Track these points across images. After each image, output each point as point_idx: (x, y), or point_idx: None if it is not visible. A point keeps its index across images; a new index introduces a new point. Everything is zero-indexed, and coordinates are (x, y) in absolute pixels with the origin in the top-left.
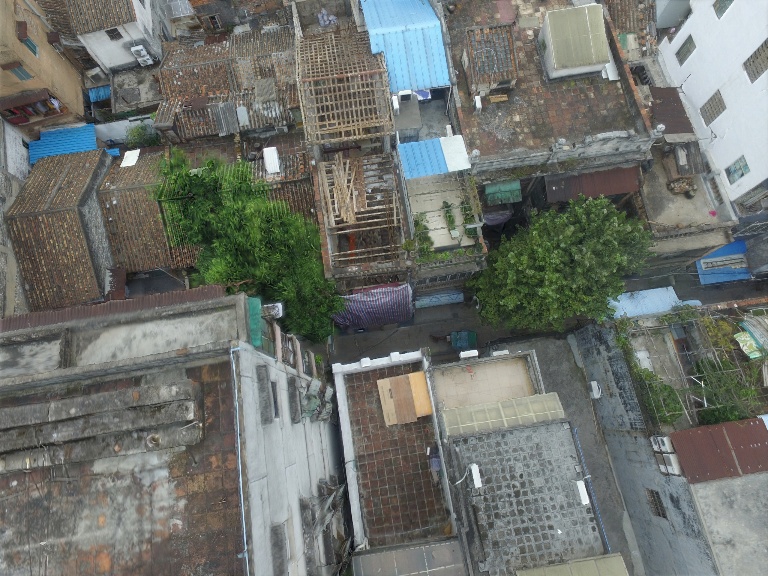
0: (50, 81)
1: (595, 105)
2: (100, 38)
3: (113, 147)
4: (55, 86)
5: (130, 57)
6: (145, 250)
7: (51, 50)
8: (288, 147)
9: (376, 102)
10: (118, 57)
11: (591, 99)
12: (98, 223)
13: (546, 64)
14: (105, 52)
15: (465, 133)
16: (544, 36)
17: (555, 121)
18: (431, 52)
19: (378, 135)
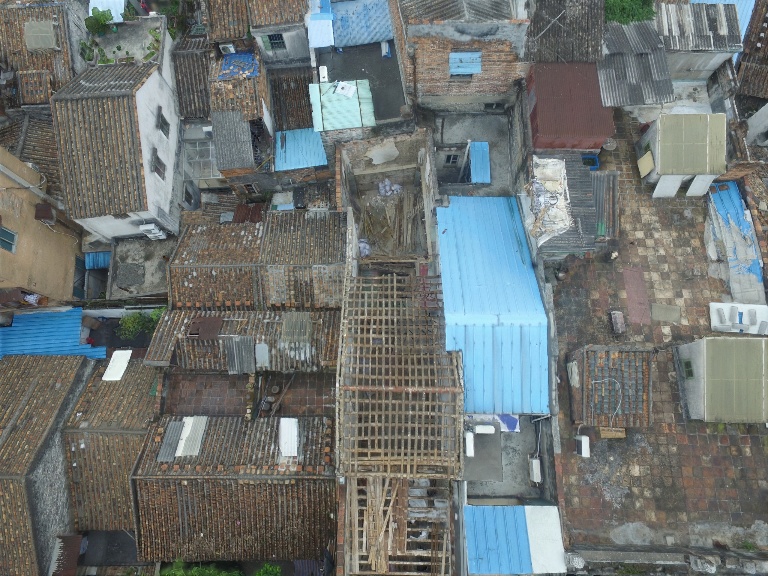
0: (27, 277)
1: (751, 469)
2: (101, 217)
3: (106, 321)
4: (33, 280)
5: (139, 230)
6: (113, 506)
7: (38, 227)
8: (315, 394)
9: (442, 433)
10: (124, 230)
11: (746, 457)
12: (56, 476)
13: (687, 395)
14: (107, 226)
15: (562, 502)
16: (692, 360)
17: (690, 485)
18: (528, 361)
19: (438, 477)
